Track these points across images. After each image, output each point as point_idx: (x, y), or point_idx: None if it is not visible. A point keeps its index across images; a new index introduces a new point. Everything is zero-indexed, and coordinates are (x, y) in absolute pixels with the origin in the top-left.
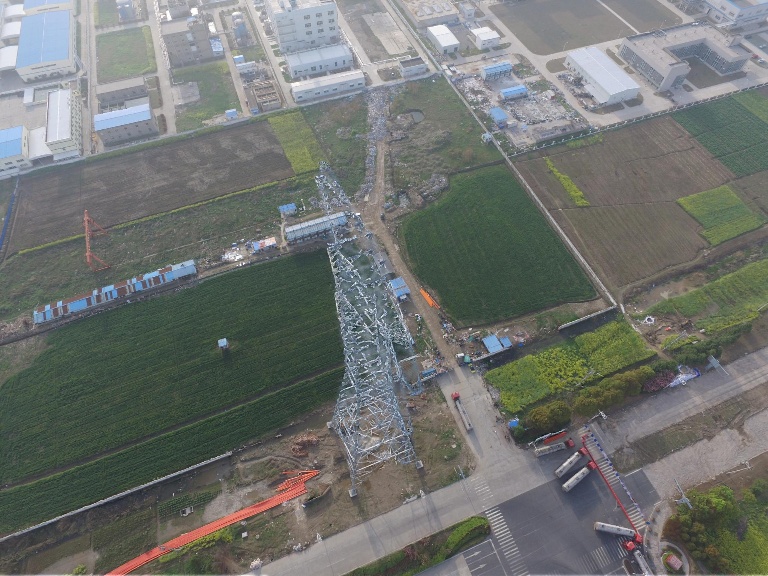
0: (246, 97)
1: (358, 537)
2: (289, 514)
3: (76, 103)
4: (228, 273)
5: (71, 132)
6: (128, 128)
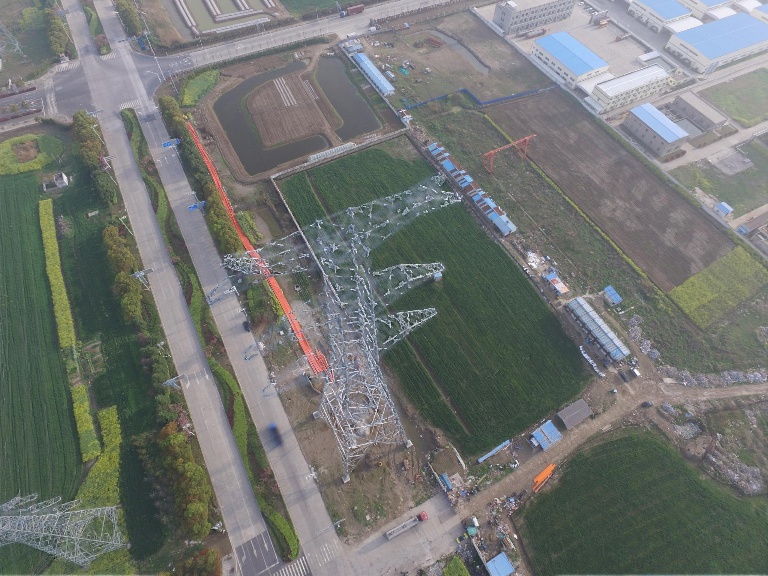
0: (759, 215)
1: (280, 425)
2: (298, 363)
3: (658, 87)
4: (513, 261)
5: (618, 95)
6: (649, 132)
